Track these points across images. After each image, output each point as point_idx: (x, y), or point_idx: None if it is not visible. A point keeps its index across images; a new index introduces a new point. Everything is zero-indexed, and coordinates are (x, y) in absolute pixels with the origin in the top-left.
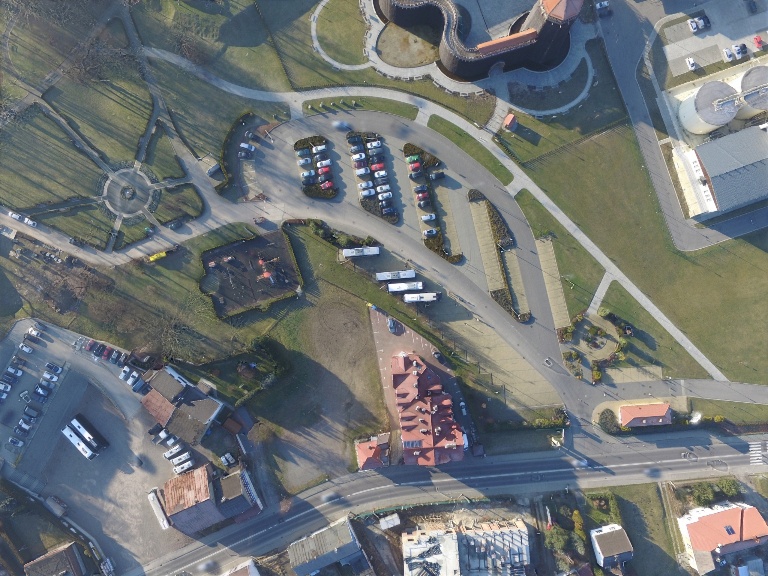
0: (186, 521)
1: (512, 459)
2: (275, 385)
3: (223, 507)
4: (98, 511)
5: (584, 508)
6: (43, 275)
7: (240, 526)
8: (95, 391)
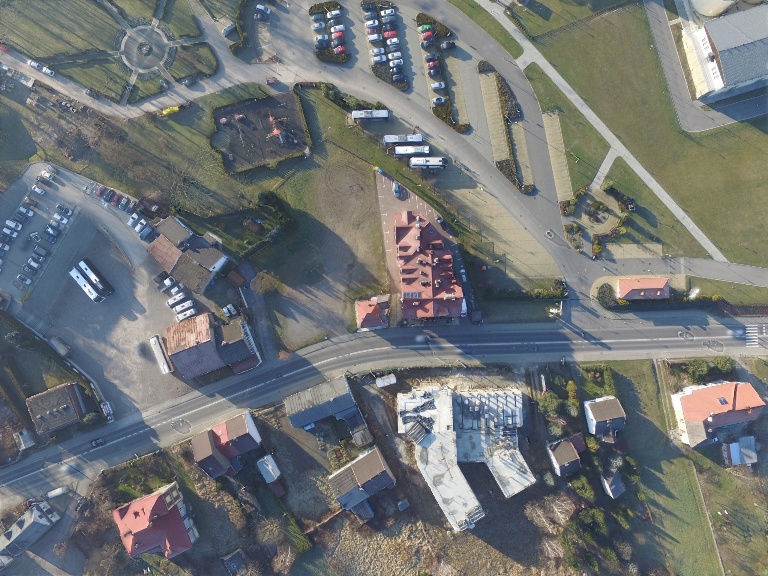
0: (186, 363)
1: (509, 329)
2: (279, 242)
3: (223, 351)
4: (100, 356)
5: (579, 380)
6: (58, 124)
7: (238, 378)
8: (103, 238)
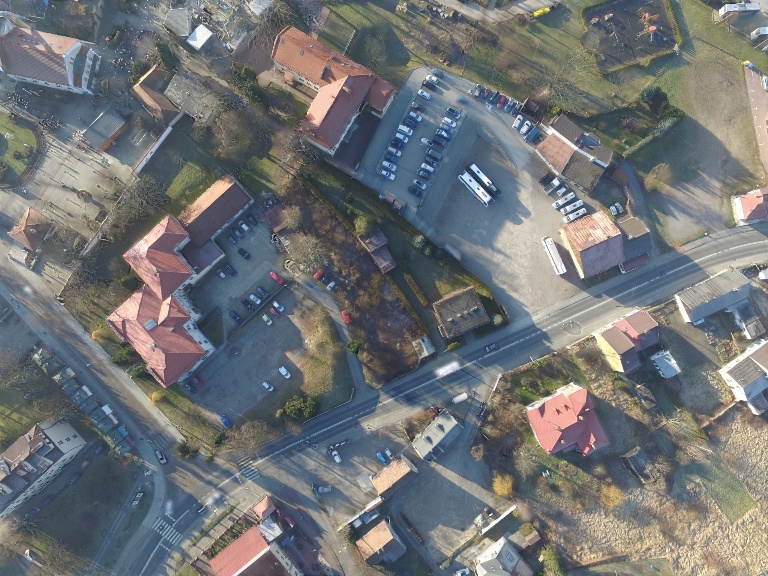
0: (592, 260)
1: None
2: (656, 140)
3: (628, 246)
4: (488, 261)
5: None
6: (429, 30)
7: (624, 278)
8: (484, 143)
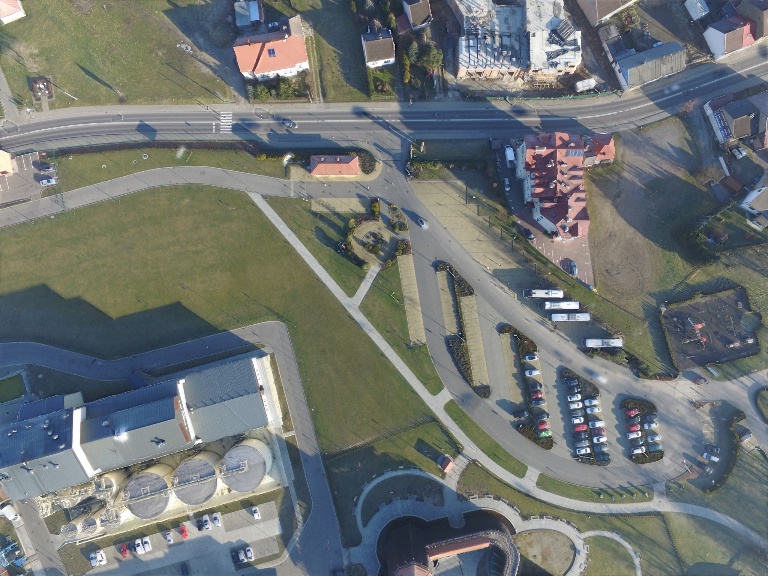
0: None
1: (461, 134)
2: (689, 220)
3: (751, 109)
4: None
5: (397, 84)
6: None
7: (726, 91)
8: None
